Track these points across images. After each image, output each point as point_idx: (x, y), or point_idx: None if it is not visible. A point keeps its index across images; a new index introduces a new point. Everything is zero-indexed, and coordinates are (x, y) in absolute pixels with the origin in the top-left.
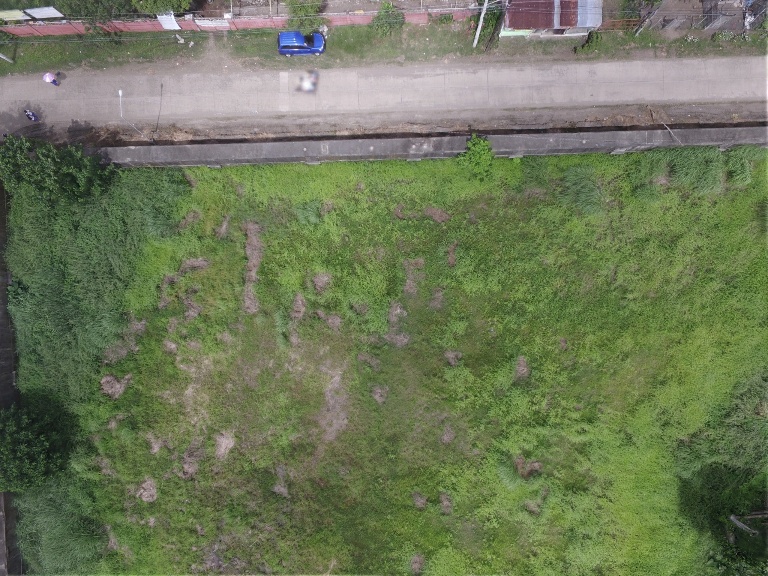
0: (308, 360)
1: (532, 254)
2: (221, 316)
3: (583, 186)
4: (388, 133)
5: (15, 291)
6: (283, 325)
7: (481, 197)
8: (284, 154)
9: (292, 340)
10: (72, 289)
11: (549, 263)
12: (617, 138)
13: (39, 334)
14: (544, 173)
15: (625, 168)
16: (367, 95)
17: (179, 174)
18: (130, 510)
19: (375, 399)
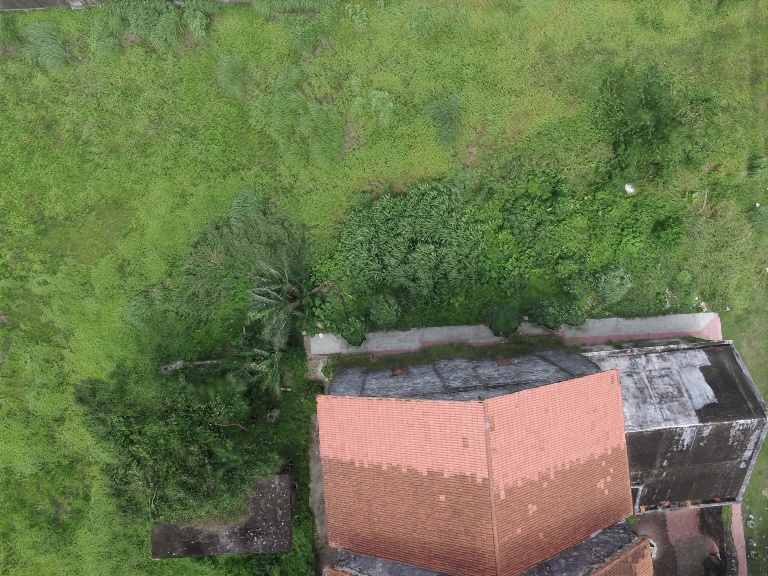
0: None
1: (3, 111)
2: None
3: (43, 40)
4: None
5: None
6: None
7: None
8: None
9: None
10: None
11: (18, 119)
12: None
13: None
14: (4, 28)
15: None
16: None
17: None
18: None
19: None
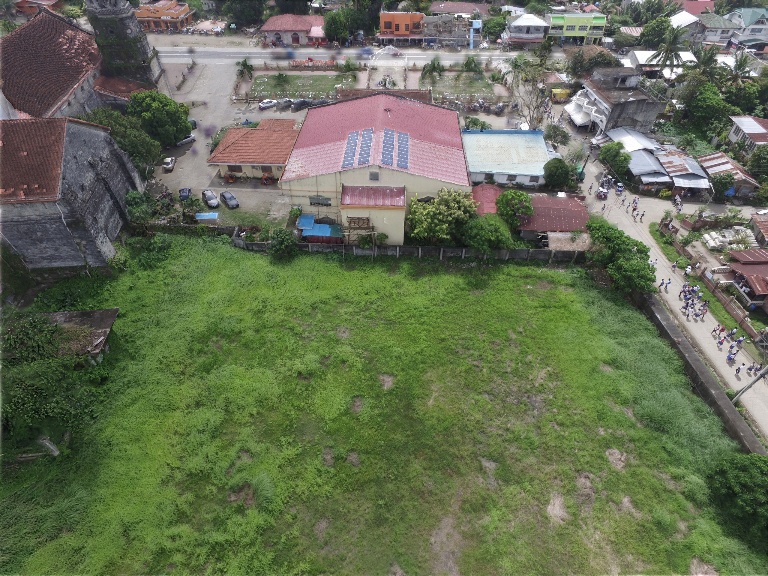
0: None
1: None
2: None
3: None
4: None
5: None
6: None
7: None
8: None
9: None
10: None
11: None
12: None
13: None
14: None
15: None
16: None
17: None
18: (626, 441)
19: (402, 569)
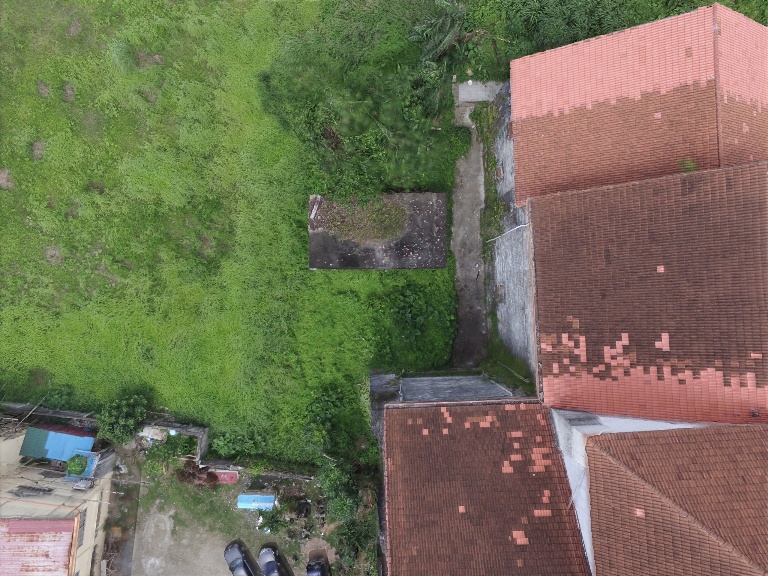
0: None
1: None
2: None
3: None
4: None
5: None
6: None
7: None
8: None
9: None
10: None
11: None
12: None
13: None
14: None
15: None
16: None
17: None
18: None
19: None
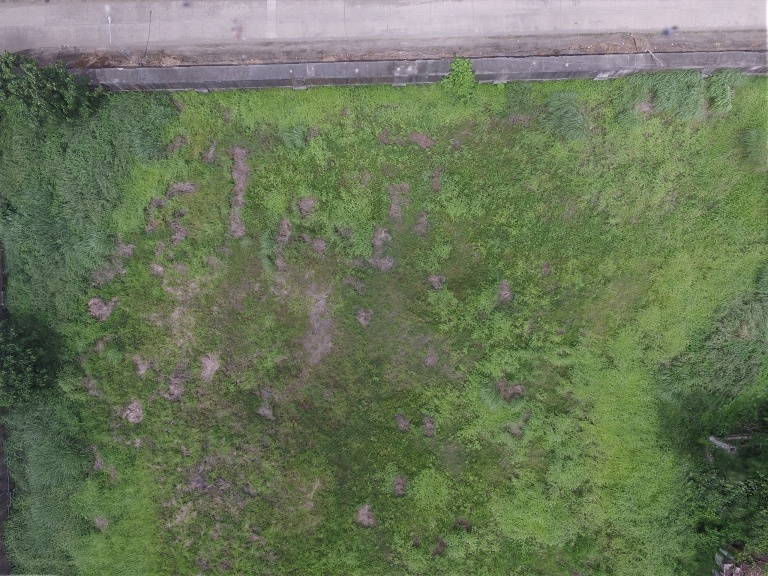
0: (293, 284)
1: (516, 180)
2: (208, 239)
3: (566, 111)
4: (374, 60)
5: (4, 212)
6: (269, 247)
7: (466, 123)
8: (270, 76)
9: (278, 264)
10: (60, 210)
11: (532, 188)
12: (600, 61)
13: (27, 253)
14: (528, 98)
15: (608, 94)
16: (354, 22)
17: (167, 98)
18: (116, 430)
19: (359, 322)
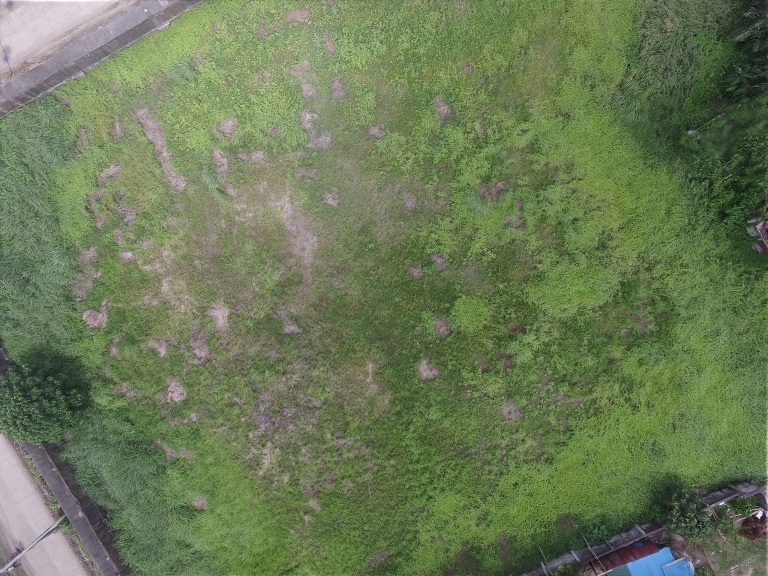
0: (254, 203)
1: (398, 4)
2: (157, 205)
3: None
4: None
5: None
6: (213, 181)
7: None
8: (130, 25)
9: (230, 193)
10: (11, 248)
11: (417, 4)
12: None
13: (3, 300)
14: None
15: None
16: None
17: (51, 99)
18: (169, 416)
19: (330, 204)
